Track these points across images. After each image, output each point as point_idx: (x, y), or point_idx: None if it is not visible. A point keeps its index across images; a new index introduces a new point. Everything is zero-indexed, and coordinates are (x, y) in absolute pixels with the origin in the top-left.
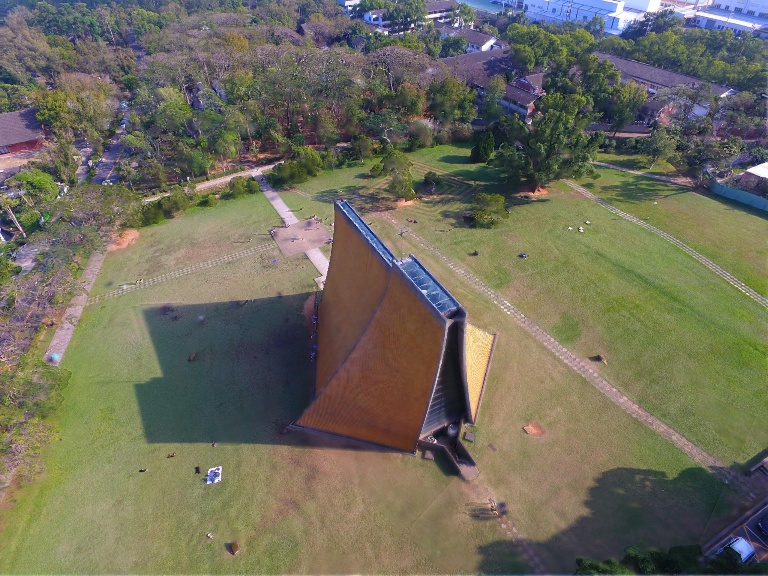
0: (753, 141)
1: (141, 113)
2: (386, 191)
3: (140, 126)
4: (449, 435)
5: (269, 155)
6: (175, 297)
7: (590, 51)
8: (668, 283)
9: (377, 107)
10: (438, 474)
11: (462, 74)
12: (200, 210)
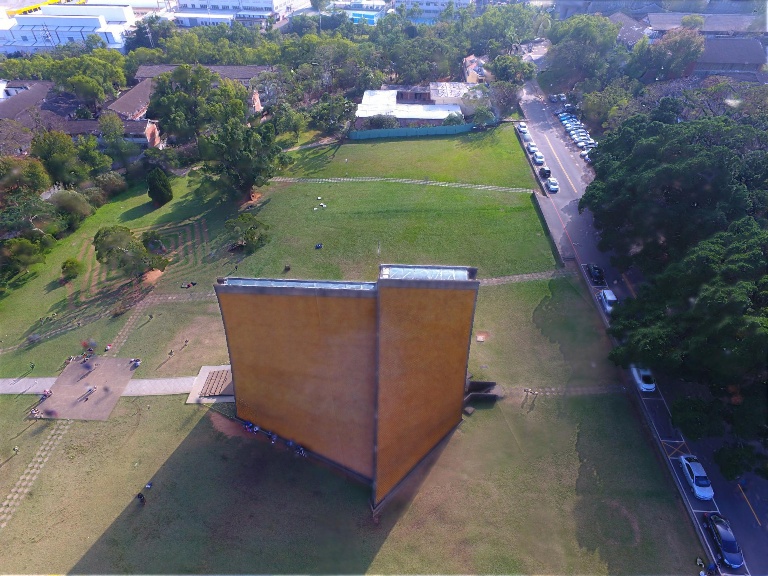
0: None
1: None
2: (113, 280)
3: None
4: None
5: None
6: None
7: (130, 67)
8: (412, 204)
9: None
10: (488, 413)
11: None
12: None
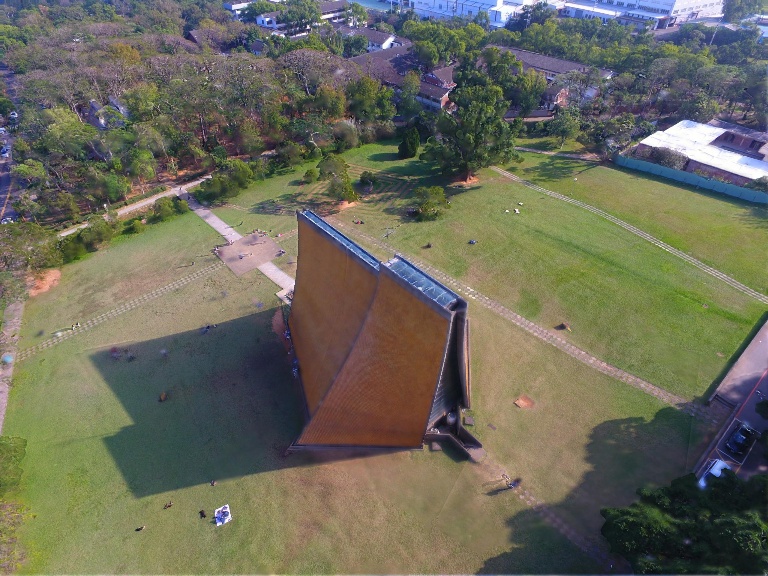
0: (637, 116)
1: (29, 139)
2: (324, 195)
3: (31, 153)
4: (449, 423)
5: (189, 171)
6: (124, 336)
7: (484, 44)
8: (602, 250)
9: (297, 112)
10: (449, 463)
11: (373, 73)
12: (126, 238)
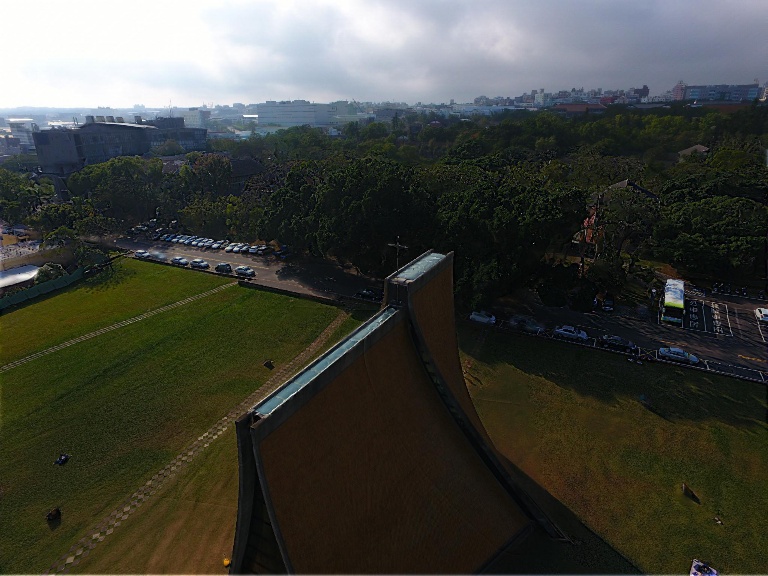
0: None
1: None
2: None
3: None
4: None
5: None
6: None
7: None
8: (130, 349)
9: None
10: None
11: None
12: None
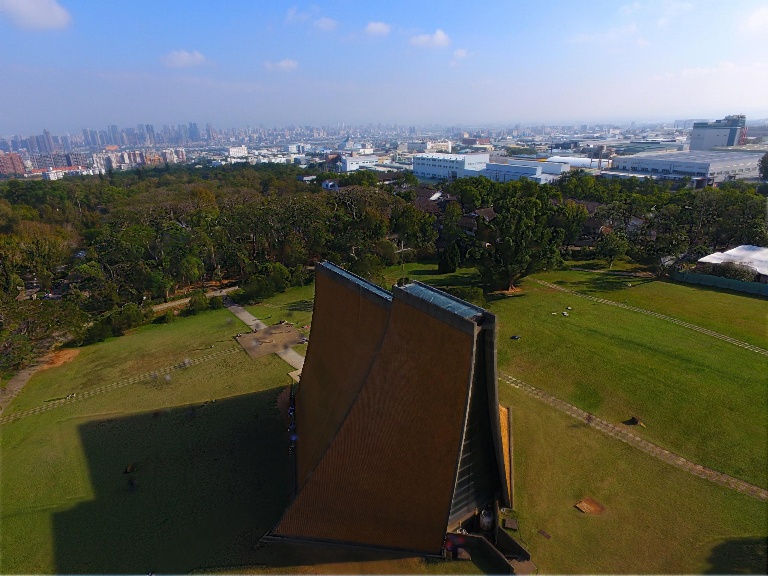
0: None
1: (100, 250)
2: None
3: (97, 261)
4: (483, 527)
5: (233, 280)
6: (115, 407)
7: None
8: (673, 348)
9: None
10: None
11: None
12: (155, 327)
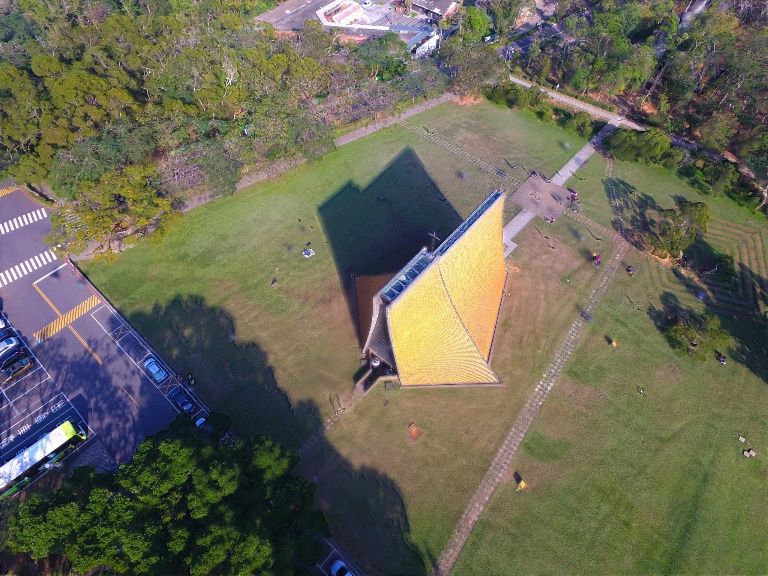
0: None
1: (620, 1)
2: None
3: None
4: None
5: None
6: (428, 160)
7: None
8: (698, 567)
9: None
10: (352, 372)
11: None
12: (532, 117)
